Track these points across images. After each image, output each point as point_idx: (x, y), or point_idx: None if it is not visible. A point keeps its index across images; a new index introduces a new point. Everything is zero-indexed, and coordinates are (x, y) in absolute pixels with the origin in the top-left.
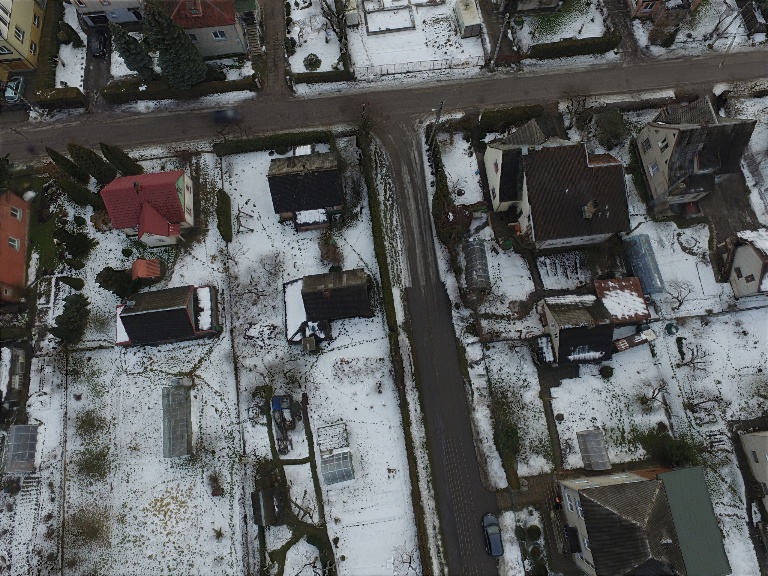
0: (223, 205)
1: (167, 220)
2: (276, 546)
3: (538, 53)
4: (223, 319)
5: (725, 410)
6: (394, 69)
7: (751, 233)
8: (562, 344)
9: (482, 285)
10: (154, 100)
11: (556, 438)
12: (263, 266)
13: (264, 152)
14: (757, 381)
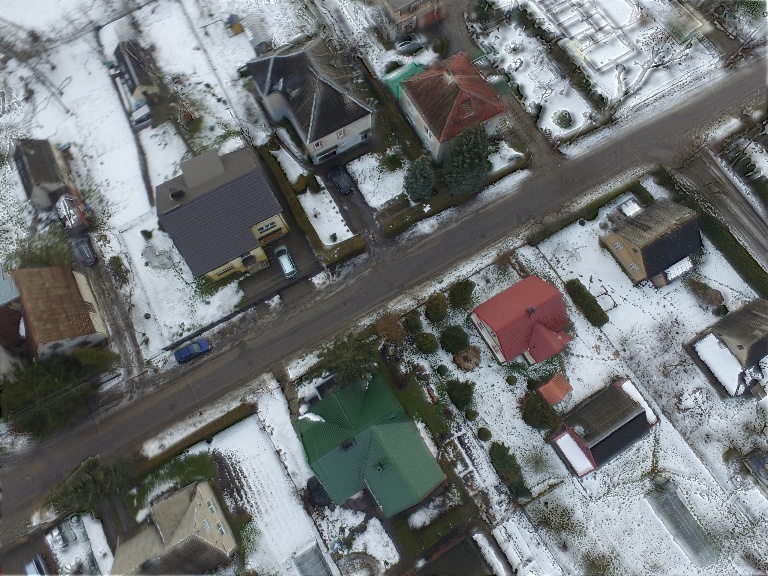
0: None
1: (553, 331)
2: None
3: (762, 34)
4: None
5: None
6: (647, 97)
7: None
8: None
9: None
10: (433, 216)
11: None
12: (660, 336)
13: (574, 224)
14: None
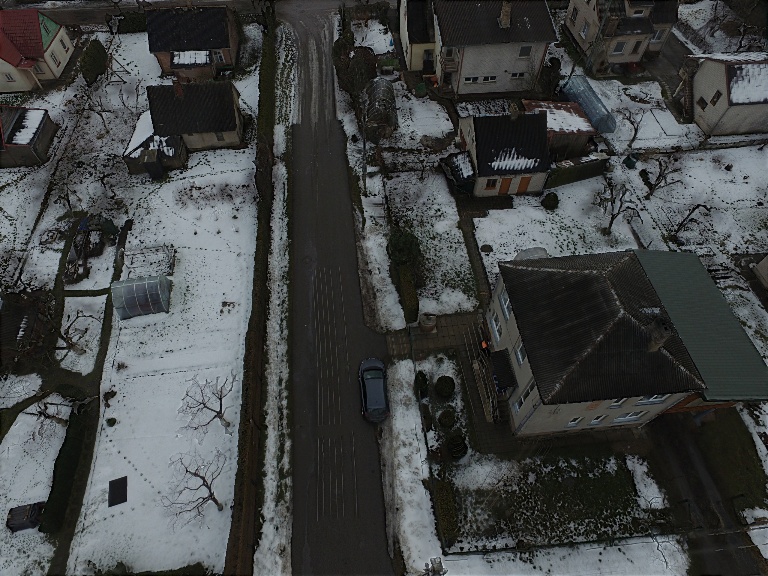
0: (94, 49)
1: (22, 54)
2: (6, 403)
3: None
4: (54, 150)
5: (723, 242)
6: None
7: (705, 54)
8: (480, 142)
9: (384, 111)
10: (64, 1)
11: (482, 271)
12: (121, 99)
13: None
14: (760, 214)
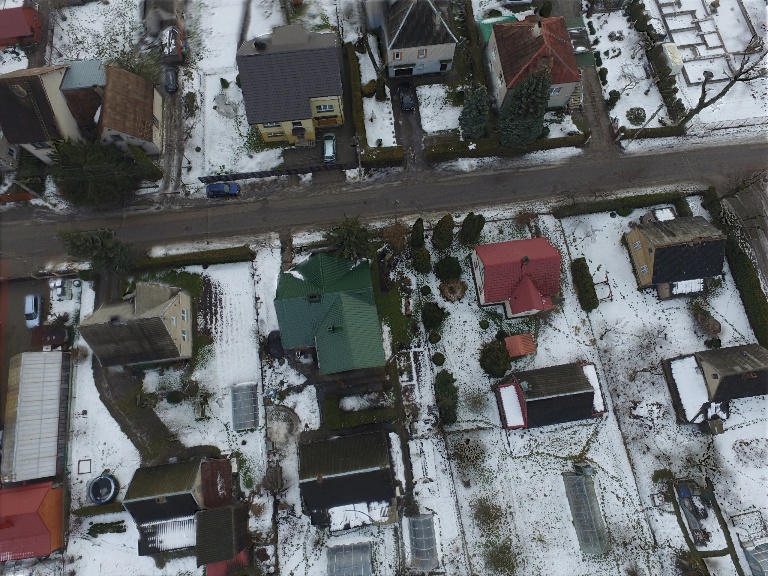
0: None
1: (540, 292)
2: None
3: None
4: None
5: None
6: (730, 124)
7: None
8: None
9: None
10: (475, 158)
11: None
12: (642, 340)
13: (605, 214)
14: None
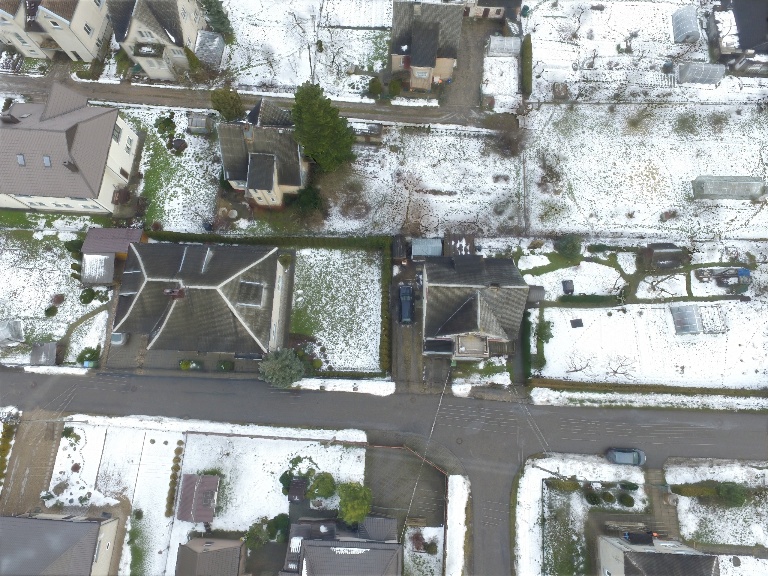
0: None
1: None
2: None
3: None
4: None
5: None
6: None
7: None
8: None
9: None
10: None
11: (715, 551)
12: None
13: None
14: None
